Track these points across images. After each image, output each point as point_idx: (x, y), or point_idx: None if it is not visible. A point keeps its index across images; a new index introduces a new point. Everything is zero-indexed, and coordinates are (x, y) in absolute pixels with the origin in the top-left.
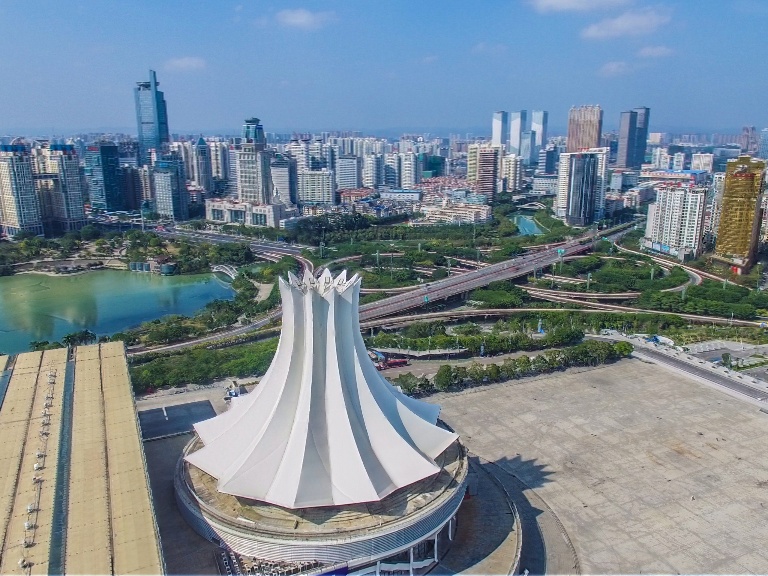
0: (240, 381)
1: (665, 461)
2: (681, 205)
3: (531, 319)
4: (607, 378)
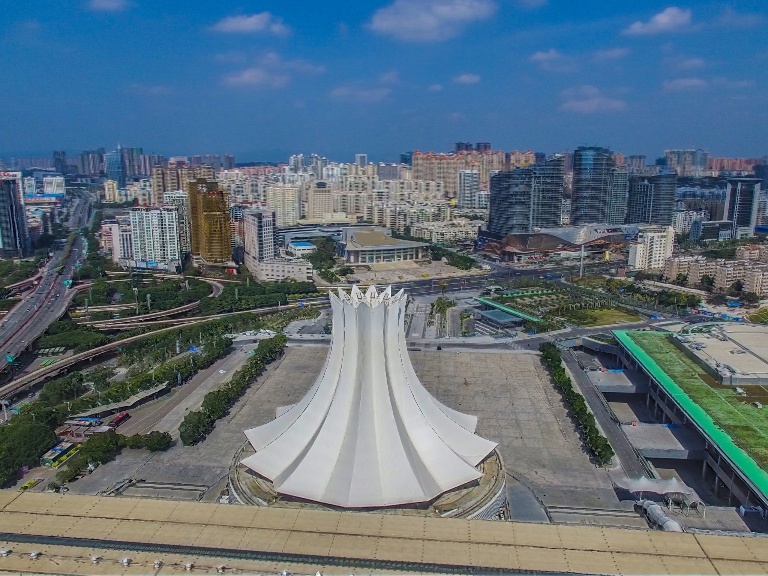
0: None
1: None
2: (159, 223)
3: (146, 346)
4: (300, 364)
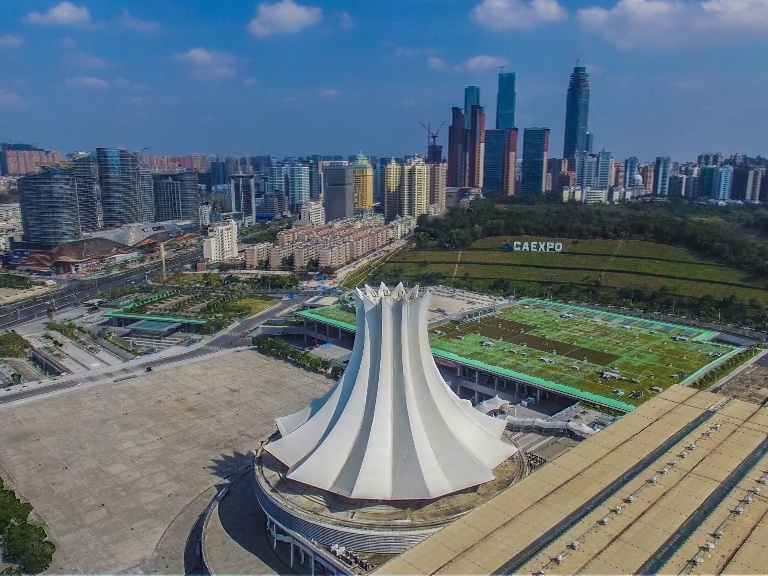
0: None
1: (207, 414)
2: None
3: None
4: (13, 434)
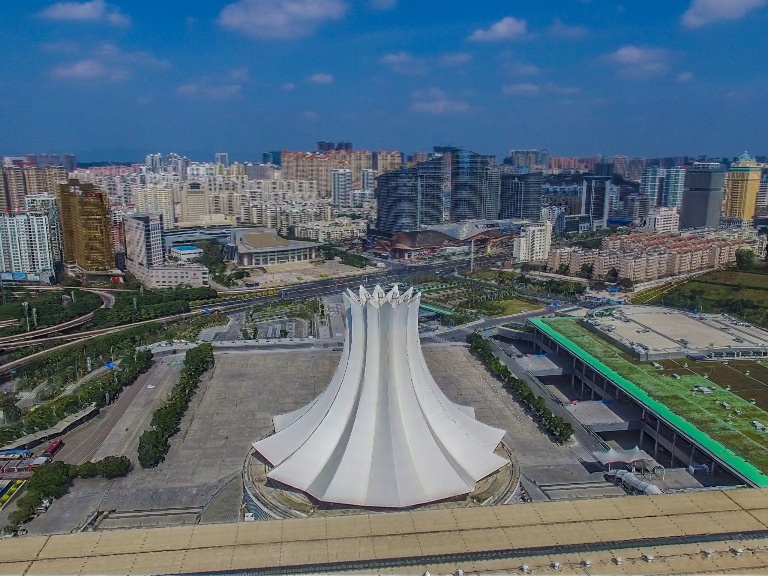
0: None
1: None
2: (27, 230)
3: (47, 366)
4: (235, 372)
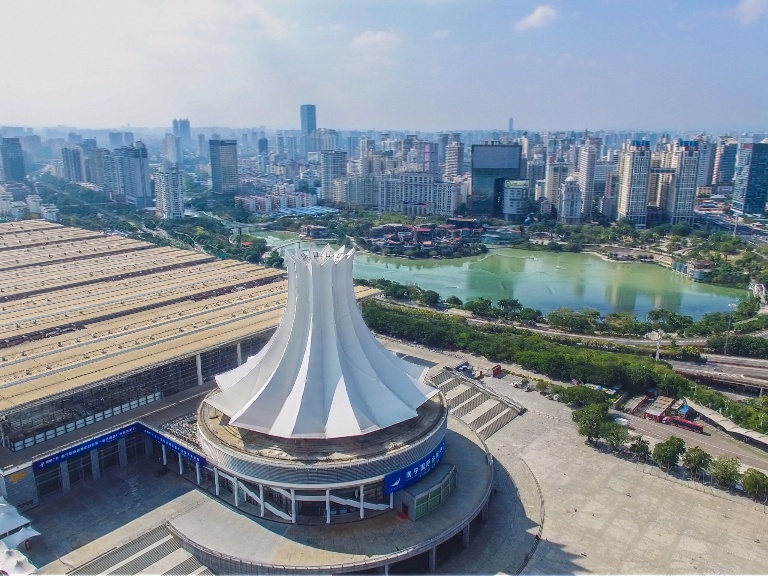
0: (518, 370)
1: None
2: None
3: None
4: None
